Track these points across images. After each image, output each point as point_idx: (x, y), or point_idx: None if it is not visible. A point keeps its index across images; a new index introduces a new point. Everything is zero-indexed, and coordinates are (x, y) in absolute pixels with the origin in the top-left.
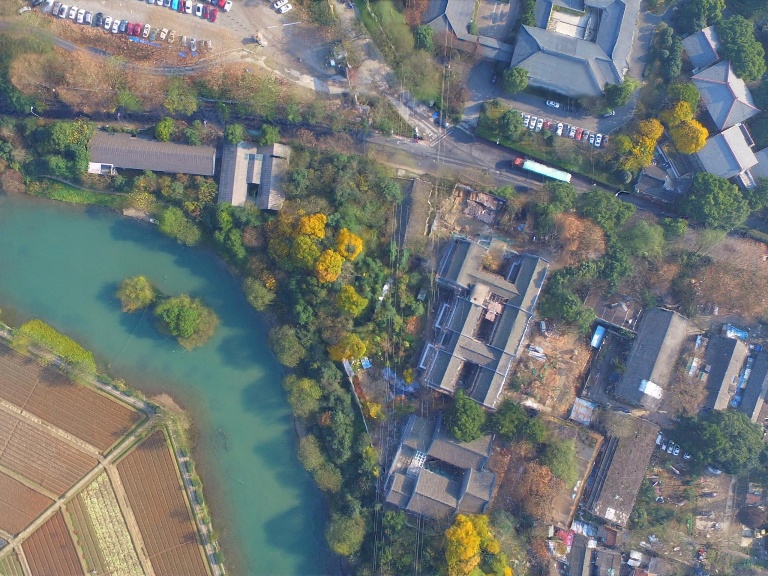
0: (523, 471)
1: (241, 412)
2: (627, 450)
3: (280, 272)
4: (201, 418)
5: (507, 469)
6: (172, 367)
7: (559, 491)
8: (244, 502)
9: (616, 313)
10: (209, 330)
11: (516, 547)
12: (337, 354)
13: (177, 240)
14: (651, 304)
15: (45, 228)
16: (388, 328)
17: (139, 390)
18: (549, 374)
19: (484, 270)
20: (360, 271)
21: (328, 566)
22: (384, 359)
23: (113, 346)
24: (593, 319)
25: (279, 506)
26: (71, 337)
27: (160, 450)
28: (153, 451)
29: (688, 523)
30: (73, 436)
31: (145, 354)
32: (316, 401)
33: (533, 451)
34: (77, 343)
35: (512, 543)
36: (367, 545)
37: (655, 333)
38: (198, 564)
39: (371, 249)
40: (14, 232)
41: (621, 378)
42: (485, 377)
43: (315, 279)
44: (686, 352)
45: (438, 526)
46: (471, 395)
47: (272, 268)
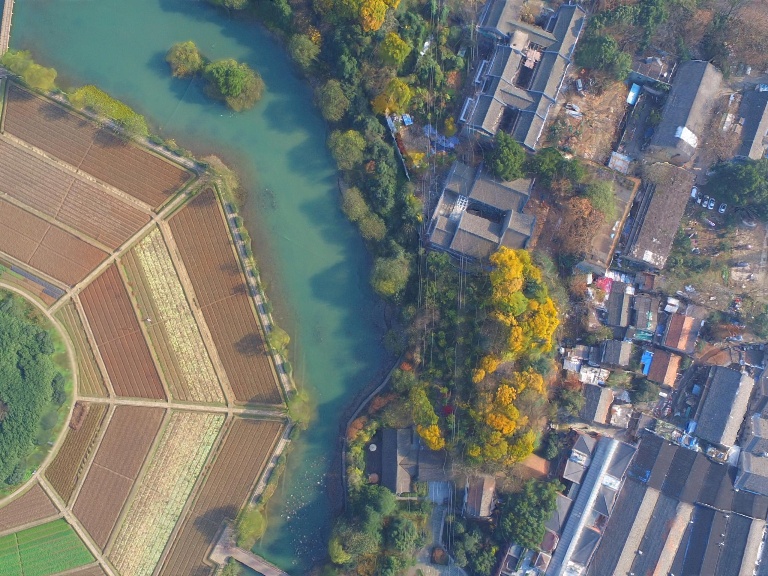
0: (562, 222)
1: (287, 173)
2: (664, 196)
3: (325, 25)
4: (249, 178)
5: (546, 220)
6: (220, 131)
7: (598, 230)
8: (291, 258)
9: (651, 68)
10: (256, 91)
11: (555, 299)
12: (381, 103)
13: (225, 3)
14: (686, 56)
15: (97, 0)
16: (430, 81)
17: (189, 150)
18: (586, 132)
19: (522, 22)
20: (402, 24)
21: (373, 318)
22: (426, 111)
23: (163, 111)
24: (629, 72)
25: (325, 261)
26: (123, 102)
27: (210, 207)
28: (203, 208)
29: (724, 274)
30: (126, 194)
31: (194, 119)
32: (360, 152)
33: (572, 191)
34: (129, 107)
35: (551, 296)
36: (412, 285)
37: (690, 83)
38: (247, 314)
39: (412, 6)
40: (68, 4)
41: (657, 129)
42: (525, 119)
43: (360, 27)
44: (720, 110)
45: (480, 266)
46: (511, 138)
47: (317, 23)
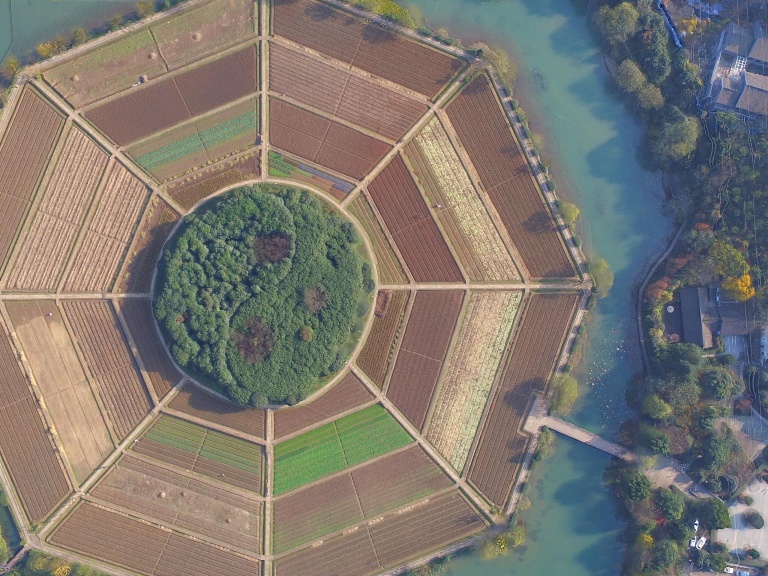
0: None
1: (553, 54)
2: None
3: None
4: (517, 62)
5: None
6: (483, 19)
7: None
8: (566, 136)
9: None
10: None
11: None
12: None
13: None
14: None
15: None
16: None
17: None
18: None
19: None
20: None
21: (652, 187)
22: None
23: (425, 4)
24: None
25: (599, 137)
26: None
27: (484, 92)
28: (477, 94)
29: None
30: (401, 86)
31: (456, 9)
32: (634, 24)
33: None
34: (393, 2)
35: None
36: (700, 147)
37: None
38: (532, 193)
39: None
40: None
41: None
42: None
43: None
44: None
45: (765, 123)
46: None
47: None
